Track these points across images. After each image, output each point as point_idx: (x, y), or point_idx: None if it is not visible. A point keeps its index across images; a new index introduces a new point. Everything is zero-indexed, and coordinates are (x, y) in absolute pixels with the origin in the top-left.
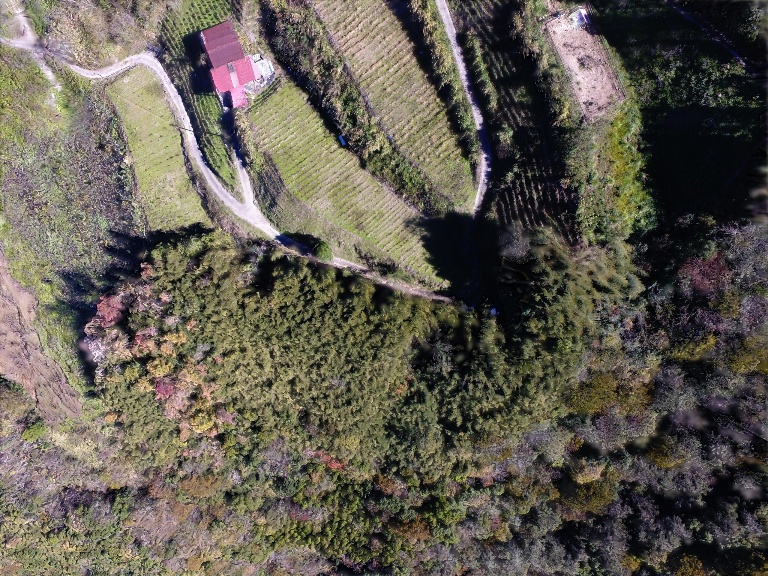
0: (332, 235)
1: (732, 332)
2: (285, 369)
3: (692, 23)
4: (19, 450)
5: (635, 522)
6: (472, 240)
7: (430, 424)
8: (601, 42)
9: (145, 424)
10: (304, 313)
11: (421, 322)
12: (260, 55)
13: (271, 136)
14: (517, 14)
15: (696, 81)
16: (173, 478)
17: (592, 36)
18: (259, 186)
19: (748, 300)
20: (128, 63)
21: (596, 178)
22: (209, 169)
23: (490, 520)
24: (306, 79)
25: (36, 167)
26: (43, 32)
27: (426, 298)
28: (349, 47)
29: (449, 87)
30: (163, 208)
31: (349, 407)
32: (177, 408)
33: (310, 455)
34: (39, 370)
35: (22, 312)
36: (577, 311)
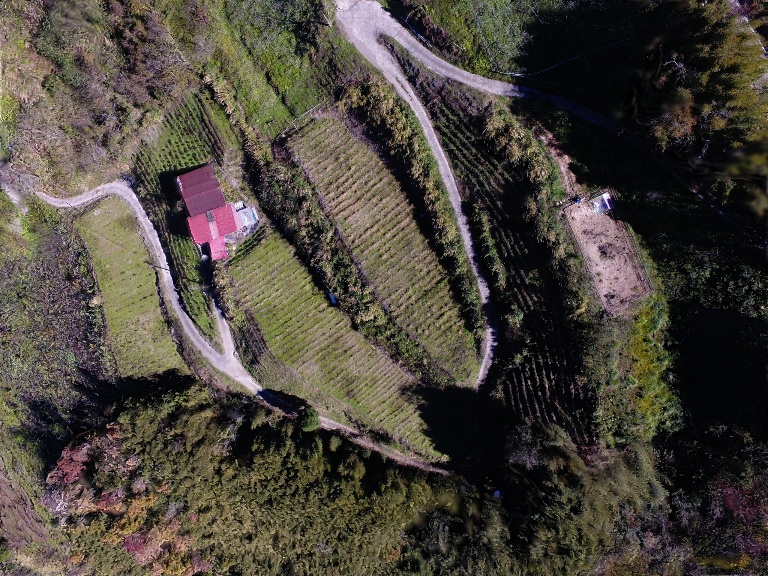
0: (319, 399)
1: (764, 537)
2: (266, 526)
3: (732, 226)
4: None
5: None
6: (475, 416)
7: None
8: (625, 229)
9: (115, 562)
10: (286, 488)
11: (416, 494)
12: (243, 203)
13: (253, 293)
14: (531, 197)
15: (734, 287)
16: None
17: (615, 222)
18: (240, 339)
19: None
20: (100, 192)
21: (617, 377)
22: (186, 314)
23: None
24: (293, 231)
25: (1, 286)
26: (9, 149)
27: (422, 470)
28: (341, 210)
29: (452, 259)
30: (135, 353)
31: (336, 568)
32: None
33: None
34: (3, 491)
35: None
36: (592, 522)
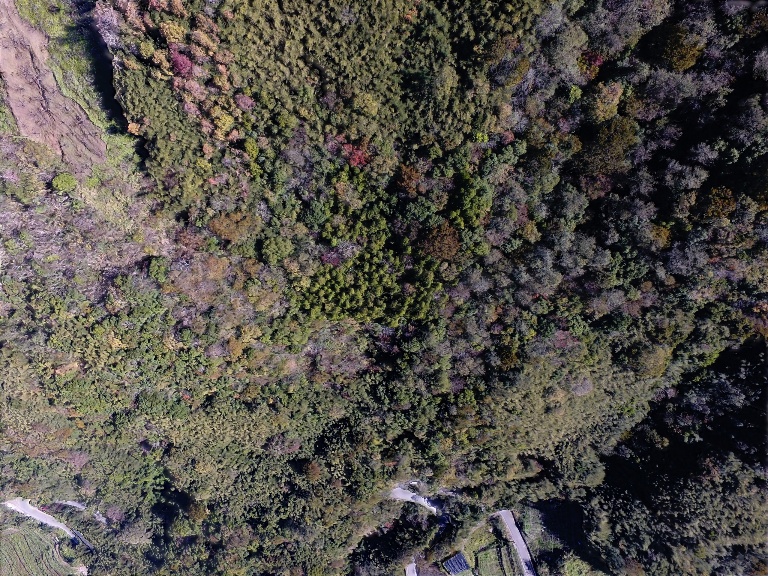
0: None
1: None
2: (295, 19)
3: None
4: (52, 220)
5: (660, 172)
6: None
7: (444, 59)
8: None
9: (168, 136)
10: None
11: None
12: None
13: None
14: None
15: None
16: (203, 217)
17: None
18: None
19: None
20: None
21: None
22: None
23: (516, 209)
24: None
25: None
26: None
27: None
28: None
29: None
30: None
31: (362, 51)
32: (196, 96)
33: (332, 149)
34: (59, 118)
35: (35, 51)
36: None
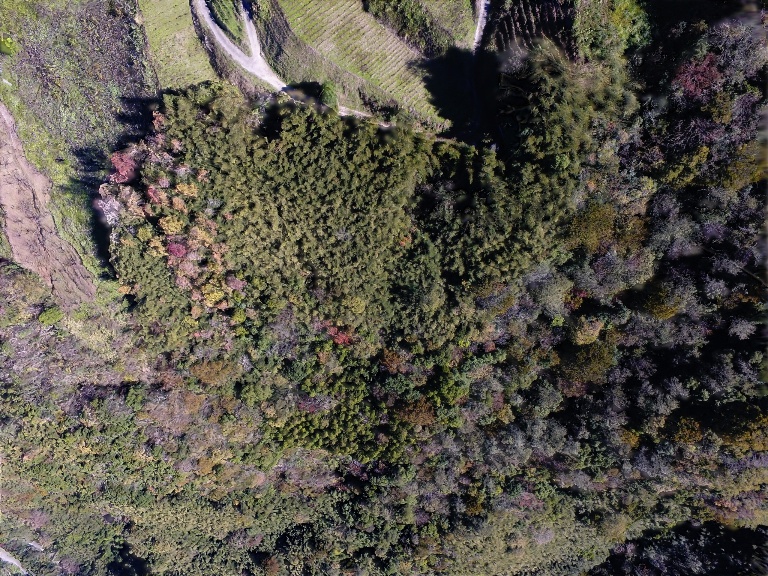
0: (337, 80)
1: (725, 153)
2: (293, 226)
3: None
4: (36, 341)
5: (634, 390)
6: (472, 76)
7: (433, 280)
8: None
9: (158, 298)
10: (311, 153)
11: (424, 166)
12: None
13: None
14: None
15: None
16: (185, 363)
17: None
18: (266, 36)
19: (740, 114)
20: None
21: None
22: (217, 25)
23: (493, 397)
24: None
25: (48, 44)
26: None
27: (428, 141)
28: None
29: None
30: (173, 66)
31: (355, 264)
32: (189, 274)
33: (317, 328)
34: (54, 255)
35: (37, 194)
36: (574, 125)
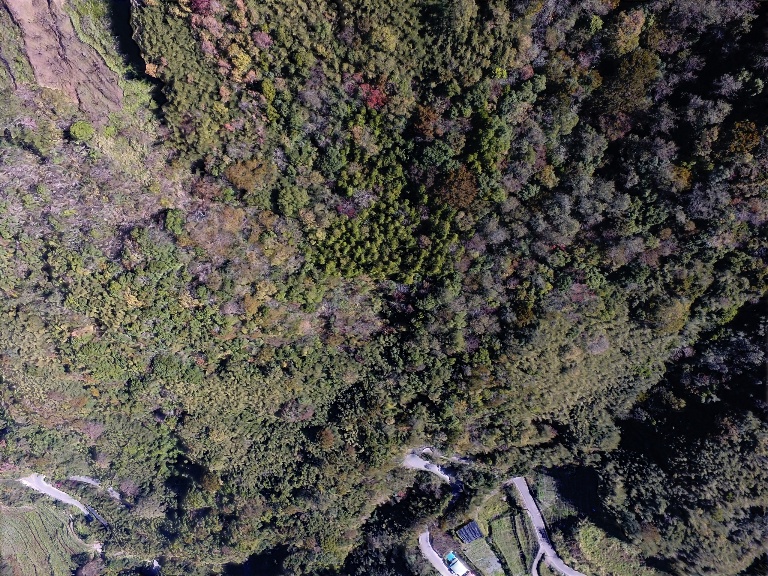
0: None
1: None
2: None
3: None
4: (69, 172)
5: (681, 108)
6: None
7: None
8: None
9: (185, 77)
10: None
11: None
12: None
13: None
14: None
15: None
16: (219, 165)
17: None
18: None
19: None
20: None
21: None
22: None
23: (535, 152)
24: None
25: None
26: None
27: None
28: None
29: None
30: None
31: None
32: (214, 34)
33: (349, 89)
34: (76, 65)
35: None
36: None
